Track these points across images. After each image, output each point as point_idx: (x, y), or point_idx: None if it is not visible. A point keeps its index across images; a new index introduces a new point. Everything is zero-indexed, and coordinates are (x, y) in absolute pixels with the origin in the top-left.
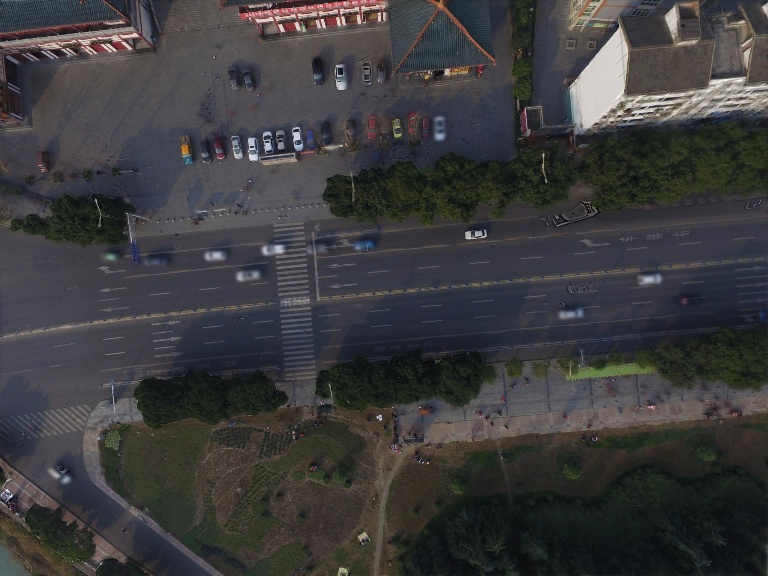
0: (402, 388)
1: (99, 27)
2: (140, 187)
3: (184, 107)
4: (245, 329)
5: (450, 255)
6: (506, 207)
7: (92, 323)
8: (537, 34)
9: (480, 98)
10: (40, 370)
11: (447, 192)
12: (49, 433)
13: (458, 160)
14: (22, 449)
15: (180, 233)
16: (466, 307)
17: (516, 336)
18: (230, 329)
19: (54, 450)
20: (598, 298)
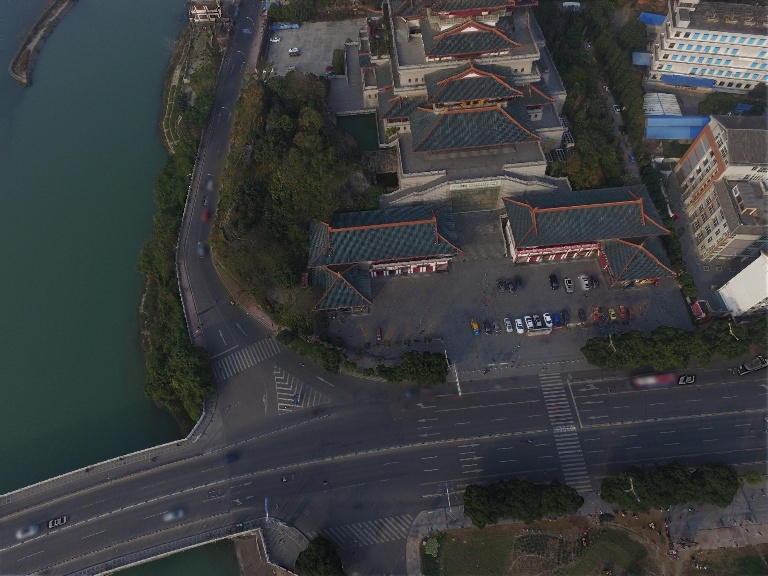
0: (679, 488)
1: (438, 257)
2: (443, 350)
3: (469, 302)
4: (530, 450)
5: (670, 395)
6: (711, 357)
7: (414, 445)
8: None
9: (660, 297)
10: (372, 484)
11: (672, 347)
12: (377, 541)
13: None
14: (353, 556)
15: (473, 380)
16: (694, 433)
17: (739, 456)
18: (518, 450)
19: (381, 557)
20: None
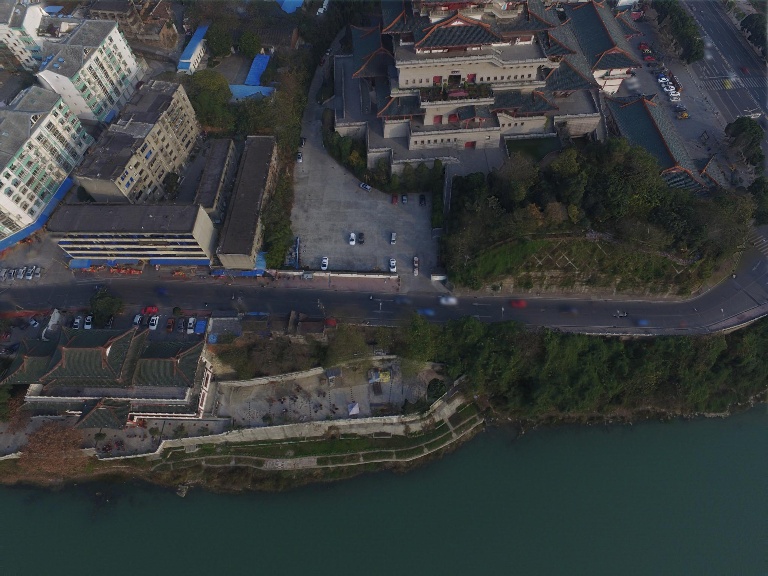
0: None
1: None
2: (709, 136)
3: None
4: (764, 99)
5: None
6: None
7: None
8: None
9: None
10: None
11: None
12: None
13: None
14: None
15: (726, 122)
16: None
17: (722, 23)
18: (766, 104)
19: None
20: (695, 4)
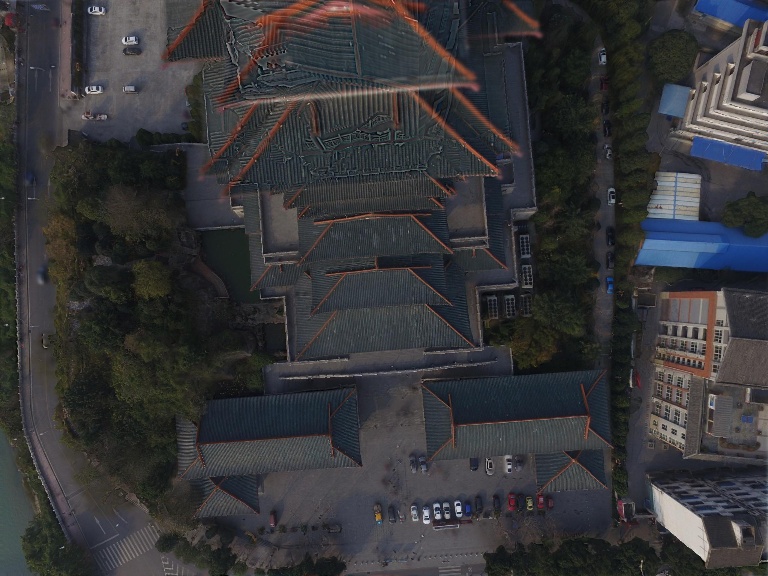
0: None
1: None
2: (342, 538)
3: (375, 481)
4: None
5: None
6: None
7: None
8: (627, 437)
9: None
10: None
11: None
12: None
13: (581, 552)
14: None
15: (371, 572)
16: None
17: None
18: None
19: None
20: None
